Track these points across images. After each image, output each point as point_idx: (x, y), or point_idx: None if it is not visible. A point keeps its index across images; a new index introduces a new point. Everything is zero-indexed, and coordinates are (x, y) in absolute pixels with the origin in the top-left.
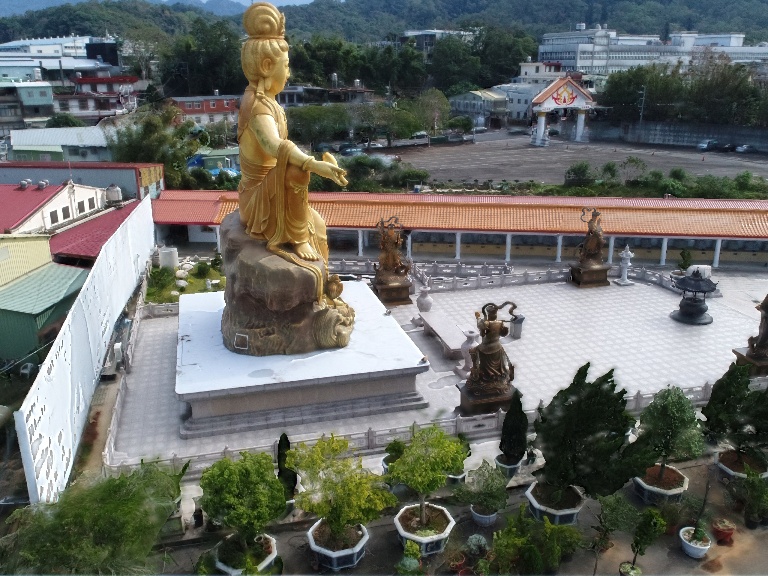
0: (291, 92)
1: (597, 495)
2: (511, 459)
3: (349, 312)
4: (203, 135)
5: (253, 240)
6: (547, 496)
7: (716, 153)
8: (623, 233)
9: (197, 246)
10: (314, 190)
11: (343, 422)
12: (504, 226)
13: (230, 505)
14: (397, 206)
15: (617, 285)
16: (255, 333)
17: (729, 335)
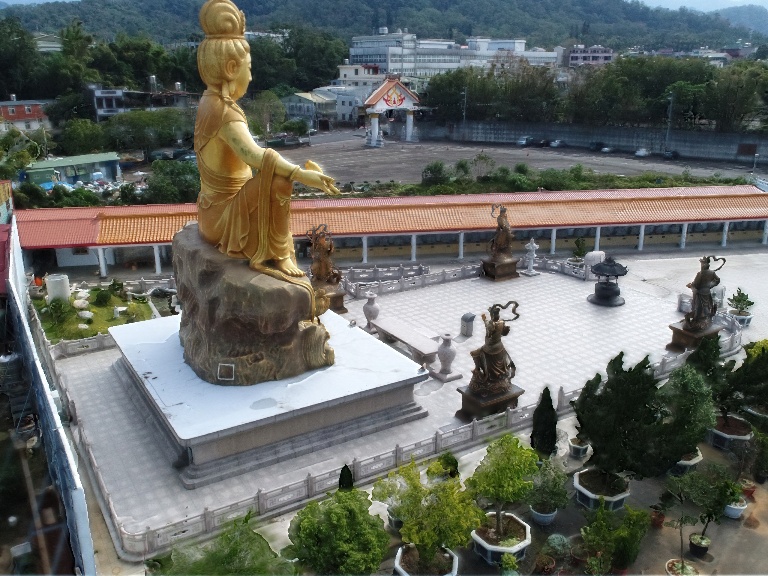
0: (109, 96)
1: (670, 476)
2: (542, 455)
3: (323, 327)
4: (31, 146)
5: (233, 259)
6: (594, 485)
7: (535, 148)
8: (519, 227)
9: (72, 271)
10: (170, 201)
11: (353, 443)
12: (410, 227)
13: (343, 553)
14: (298, 213)
15: (526, 276)
16: (242, 361)
17: (645, 313)
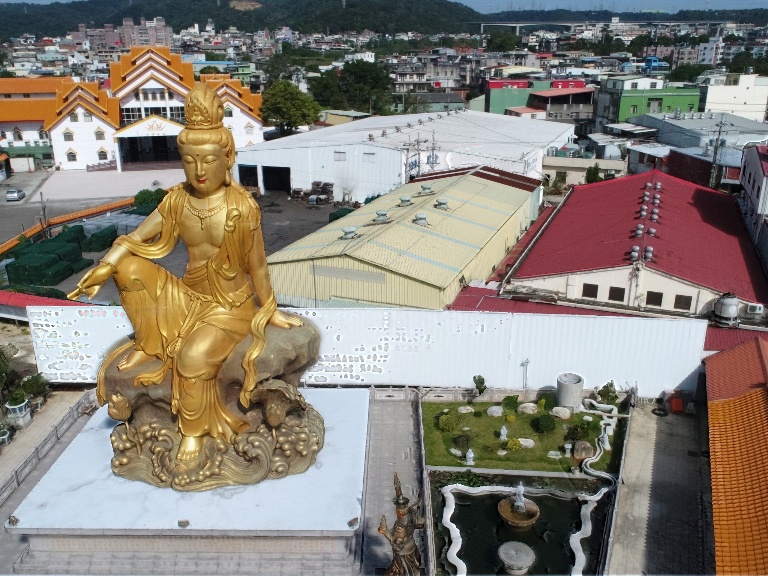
0: None
1: None
2: None
3: None
4: None
5: None
6: None
7: None
8: None
9: None
10: None
11: None
12: None
13: None
14: None
15: None
16: None
17: None
